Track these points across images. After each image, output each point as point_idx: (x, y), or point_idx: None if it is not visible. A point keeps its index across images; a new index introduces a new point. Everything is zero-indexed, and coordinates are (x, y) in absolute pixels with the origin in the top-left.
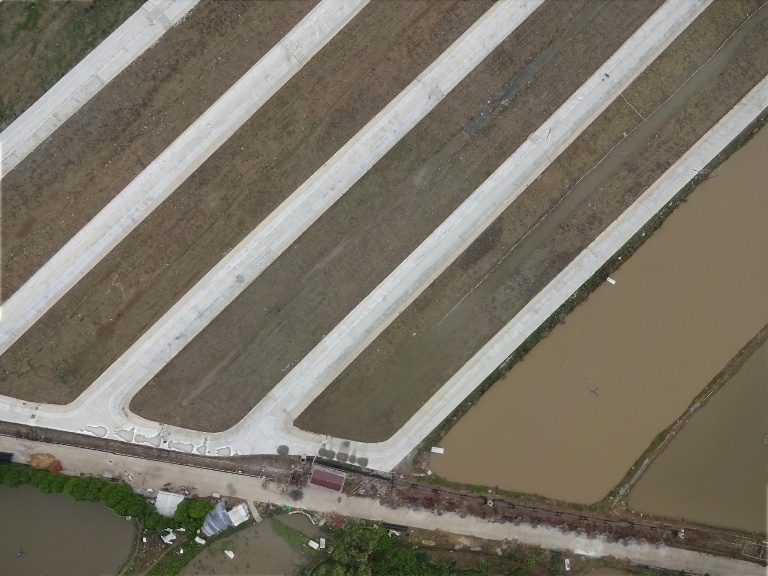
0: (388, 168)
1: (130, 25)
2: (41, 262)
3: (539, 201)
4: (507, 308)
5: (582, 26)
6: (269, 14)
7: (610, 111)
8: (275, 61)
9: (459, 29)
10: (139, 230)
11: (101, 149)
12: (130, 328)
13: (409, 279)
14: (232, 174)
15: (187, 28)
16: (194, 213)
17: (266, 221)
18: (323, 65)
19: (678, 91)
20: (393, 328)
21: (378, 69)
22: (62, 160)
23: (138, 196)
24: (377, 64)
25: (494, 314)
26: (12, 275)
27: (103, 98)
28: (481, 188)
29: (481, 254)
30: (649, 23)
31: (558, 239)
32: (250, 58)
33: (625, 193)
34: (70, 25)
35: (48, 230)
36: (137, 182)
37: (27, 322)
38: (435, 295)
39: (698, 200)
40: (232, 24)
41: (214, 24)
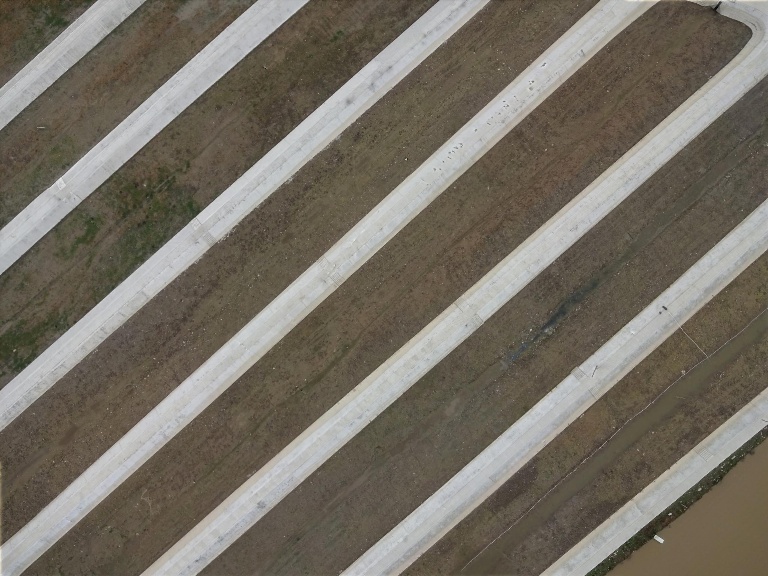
0: (419, 396)
1: (177, 242)
2: (79, 471)
3: (580, 442)
4: (538, 559)
5: (640, 249)
6: (310, 231)
7: (667, 346)
8: (311, 282)
9: (503, 251)
10: (170, 446)
11: (141, 362)
12: (154, 544)
13: (433, 520)
14: (262, 394)
15: (230, 244)
16: (223, 432)
17: (291, 445)
18: (359, 285)
19: (749, 325)
20: (413, 570)
21: (415, 291)
22: (106, 371)
23: (171, 414)
24: (415, 285)
25: (523, 564)
26: (52, 482)
27: (147, 312)
28: (517, 425)
29: (513, 497)
30: (718, 249)
31: (600, 486)
32: (288, 276)
33: (680, 439)
34: (123, 239)
35: (87, 440)
36: (171, 399)
37: (61, 530)
38: (460, 537)
39: (767, 453)
40: (273, 241)
41: (256, 241)
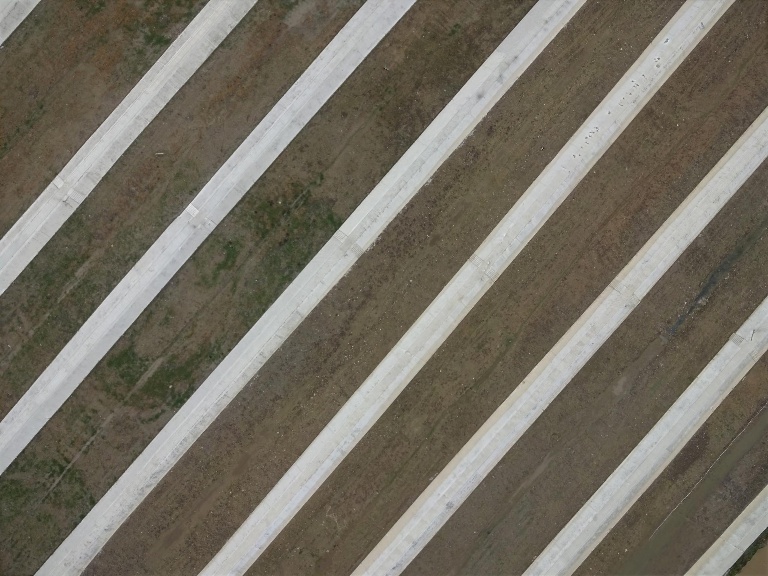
0: (587, 380)
1: (325, 257)
2: (258, 498)
3: (745, 404)
4: (719, 518)
5: None
6: (456, 231)
7: None
8: (468, 282)
9: (649, 229)
10: (348, 461)
11: (305, 382)
12: (346, 558)
13: (619, 497)
14: (432, 398)
15: (378, 253)
16: (399, 440)
17: (470, 444)
18: (514, 279)
19: None
20: (604, 545)
21: (569, 278)
22: (270, 396)
23: (346, 429)
24: (568, 273)
25: (706, 525)
26: (233, 513)
27: (303, 331)
28: (685, 395)
29: (689, 463)
30: None
31: None
32: (441, 278)
33: None
34: (266, 260)
35: (262, 466)
36: (343, 414)
37: (251, 559)
38: (644, 509)
39: None
40: (421, 244)
41: (403, 246)
